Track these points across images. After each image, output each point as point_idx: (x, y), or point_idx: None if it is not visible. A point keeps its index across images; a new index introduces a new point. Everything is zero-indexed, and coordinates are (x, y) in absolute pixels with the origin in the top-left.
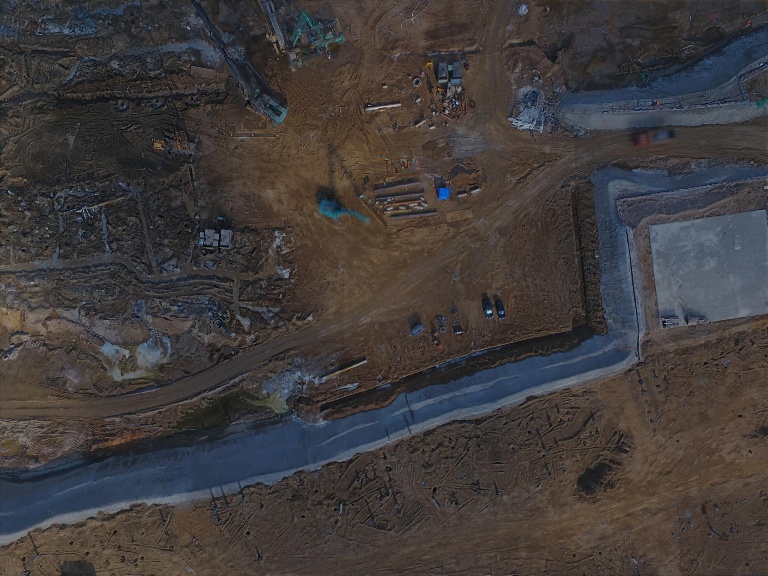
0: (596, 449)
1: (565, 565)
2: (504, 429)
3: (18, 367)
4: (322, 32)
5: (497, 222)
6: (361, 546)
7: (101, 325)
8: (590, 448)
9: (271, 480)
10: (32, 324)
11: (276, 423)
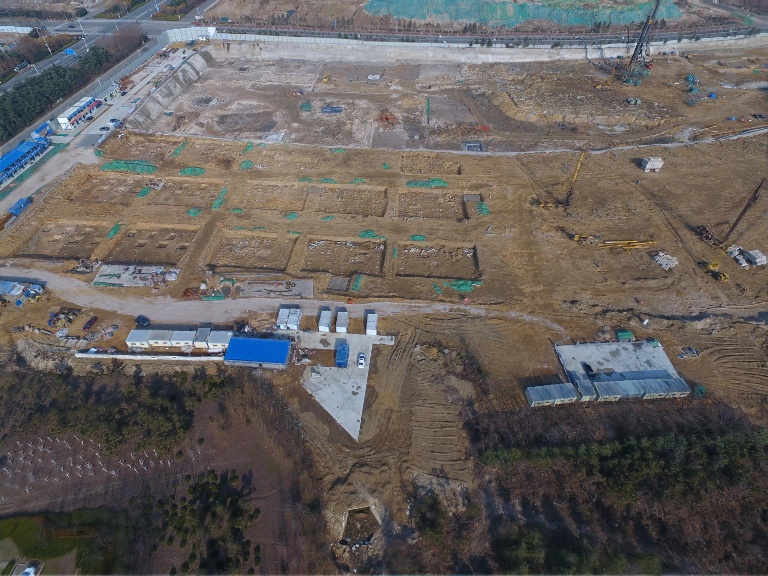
0: None
1: None
2: None
3: (566, 129)
4: (642, 70)
5: (739, 102)
6: None
7: (599, 118)
8: None
9: None
10: (568, 120)
11: None
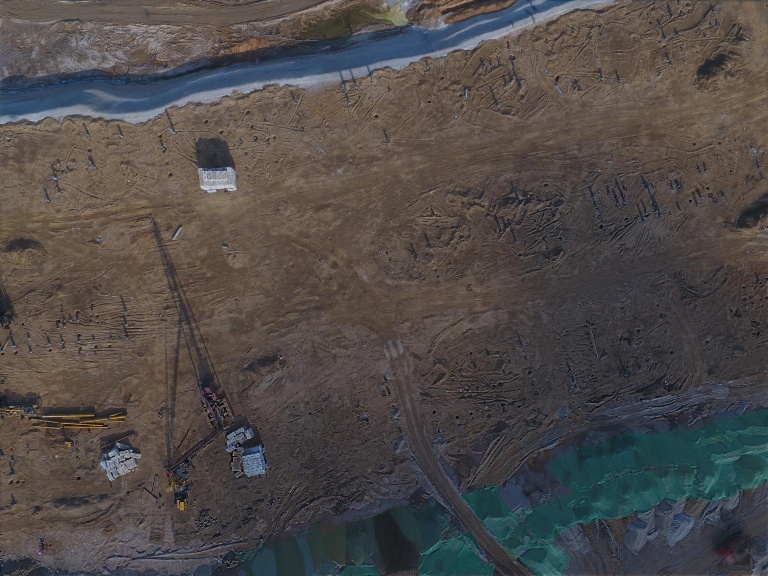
0: (715, 40)
1: (685, 153)
2: (625, 19)
3: None
4: None
5: None
6: (486, 131)
7: None
8: (710, 39)
9: (399, 64)
10: None
11: (396, 34)
